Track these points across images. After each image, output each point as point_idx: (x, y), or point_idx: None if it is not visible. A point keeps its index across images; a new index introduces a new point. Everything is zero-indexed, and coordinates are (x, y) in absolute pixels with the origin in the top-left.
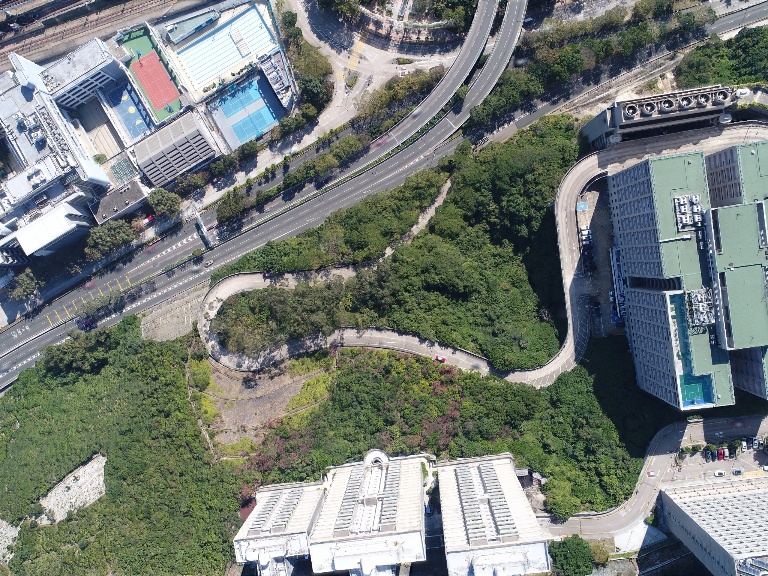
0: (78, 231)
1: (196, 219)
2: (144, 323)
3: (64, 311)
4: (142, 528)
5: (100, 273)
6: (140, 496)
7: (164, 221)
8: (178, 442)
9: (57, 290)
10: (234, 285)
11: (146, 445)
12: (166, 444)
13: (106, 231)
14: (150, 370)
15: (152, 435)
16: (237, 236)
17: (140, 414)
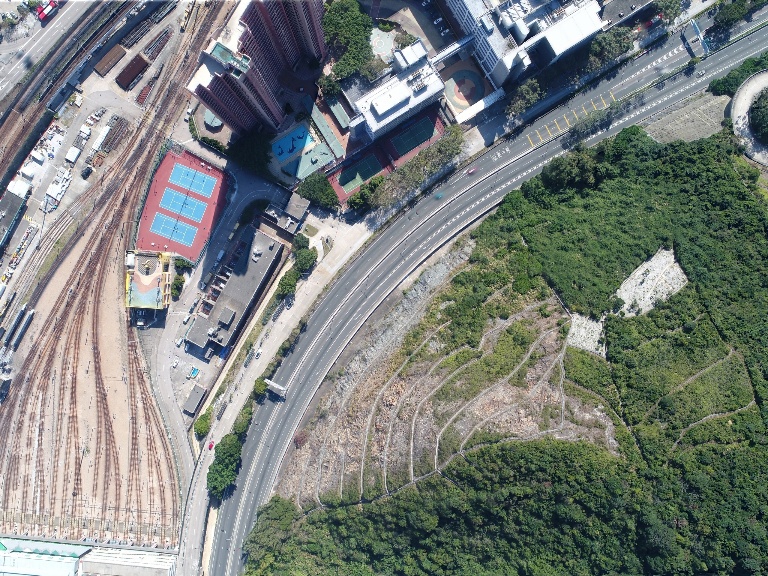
0: (592, 35)
1: (681, 31)
2: (650, 132)
3: (546, 131)
4: (749, 307)
5: (584, 90)
6: (732, 279)
7: (648, 34)
8: (752, 228)
9: (537, 109)
10: (763, 81)
11: (712, 236)
12: (732, 234)
13: (613, 37)
14: (687, 169)
15: (714, 227)
16: (731, 44)
17: (692, 209)
